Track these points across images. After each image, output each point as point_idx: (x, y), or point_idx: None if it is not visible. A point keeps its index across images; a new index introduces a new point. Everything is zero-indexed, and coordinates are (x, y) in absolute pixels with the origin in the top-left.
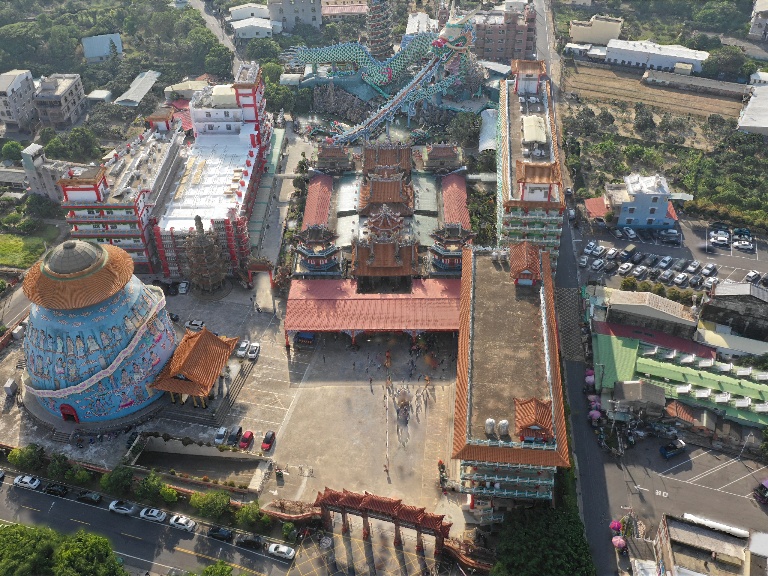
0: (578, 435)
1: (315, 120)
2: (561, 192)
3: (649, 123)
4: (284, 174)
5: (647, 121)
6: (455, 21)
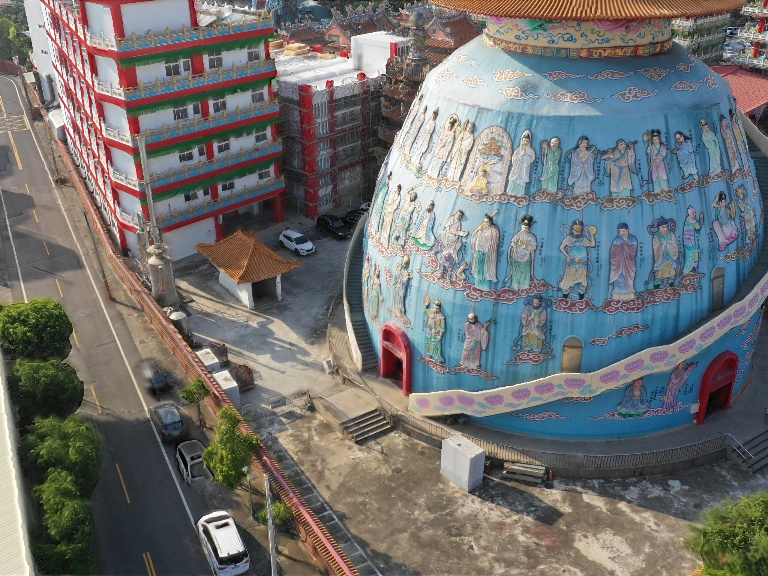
0: None
1: None
2: None
3: None
4: None
5: None
6: None
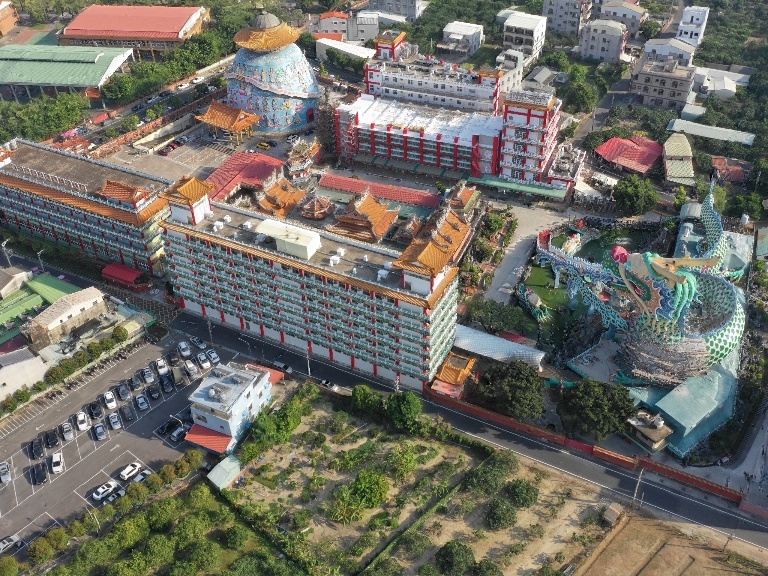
0: (35, 265)
1: (620, 242)
2: (182, 229)
3: (445, 554)
4: (462, 183)
5: (452, 554)
6: (662, 262)
